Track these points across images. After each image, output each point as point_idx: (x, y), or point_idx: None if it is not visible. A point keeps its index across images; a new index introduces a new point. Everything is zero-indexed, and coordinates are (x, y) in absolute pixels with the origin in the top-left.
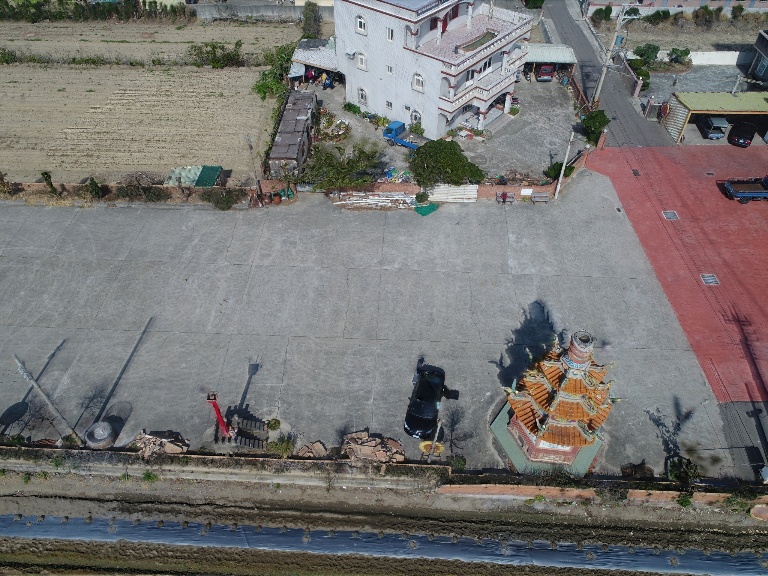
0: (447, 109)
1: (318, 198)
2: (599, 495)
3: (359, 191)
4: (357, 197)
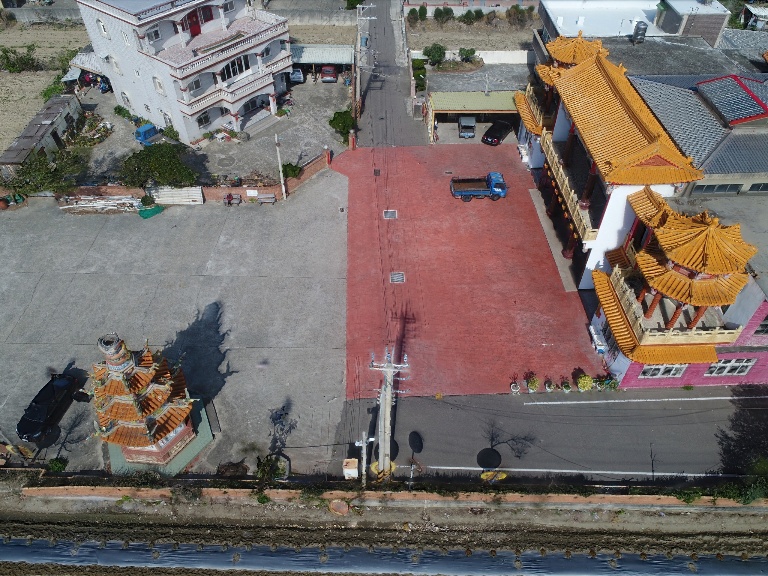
0: (187, 112)
1: (47, 203)
2: (172, 494)
3: (88, 195)
4: (85, 201)
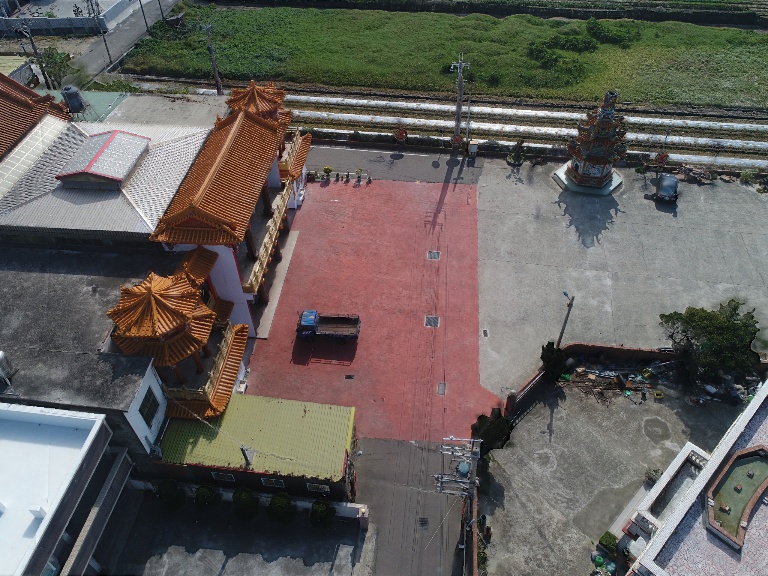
0: None
1: None
2: None
3: None
4: None
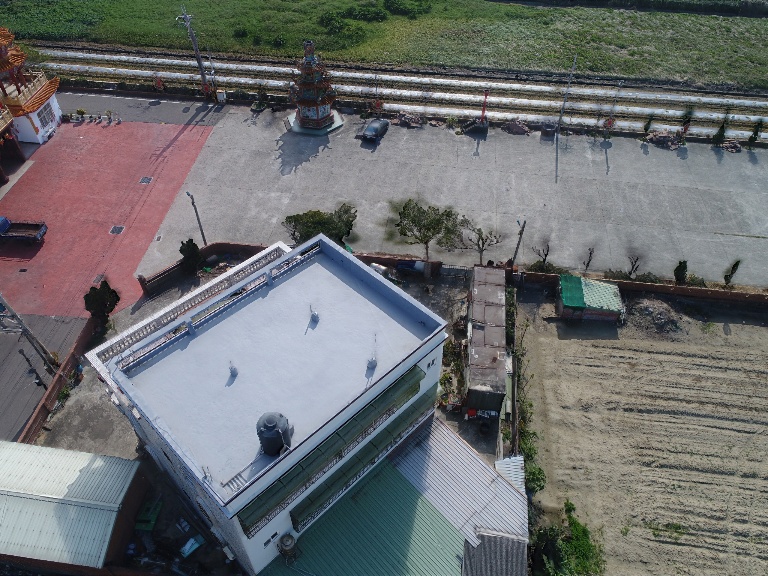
0: None
1: None
2: None
3: None
4: None
